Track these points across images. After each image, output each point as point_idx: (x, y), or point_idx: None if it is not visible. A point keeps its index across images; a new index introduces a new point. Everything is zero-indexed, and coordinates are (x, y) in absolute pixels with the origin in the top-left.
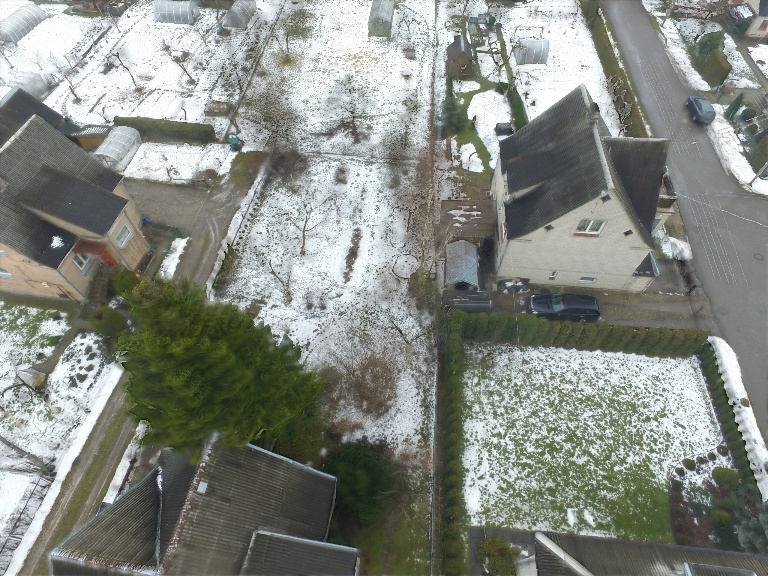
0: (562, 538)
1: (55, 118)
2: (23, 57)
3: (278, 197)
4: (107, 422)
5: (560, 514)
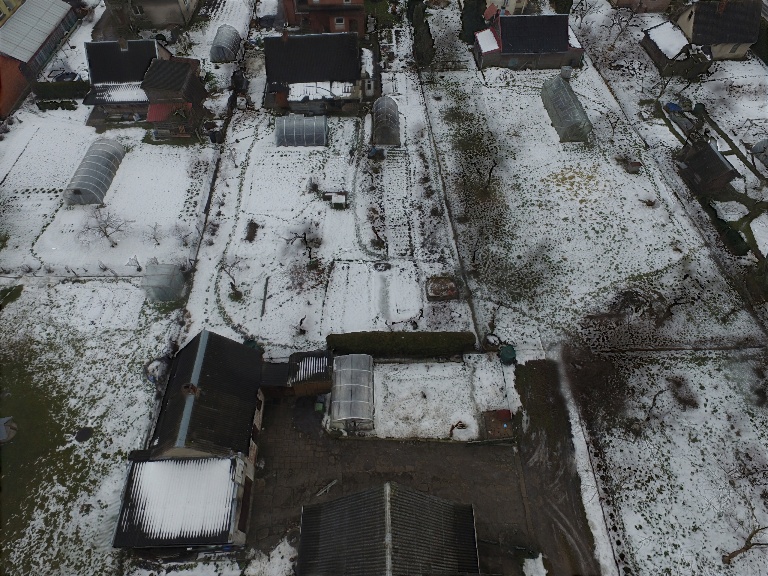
0: None
1: (256, 360)
2: (129, 230)
3: (620, 447)
4: None
5: None
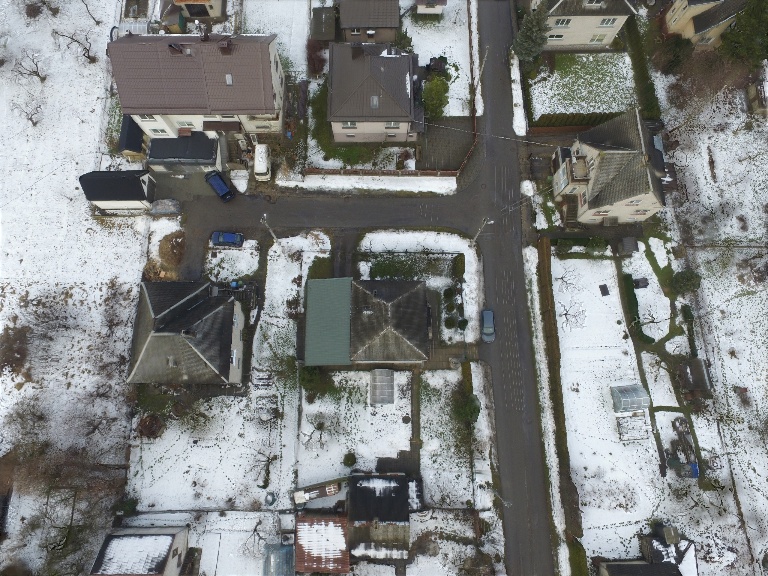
0: (630, 13)
1: None
2: None
3: None
4: None
5: (595, 59)
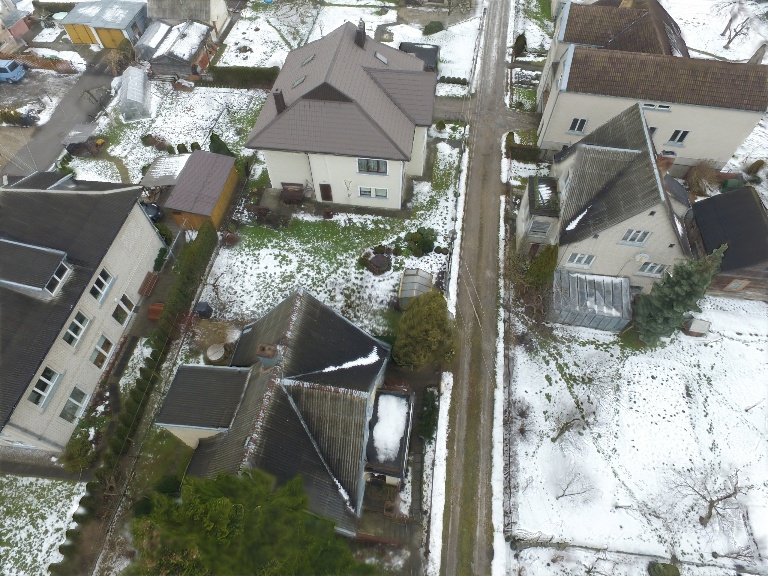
0: None
1: None
2: None
3: None
4: None
5: (2, 492)
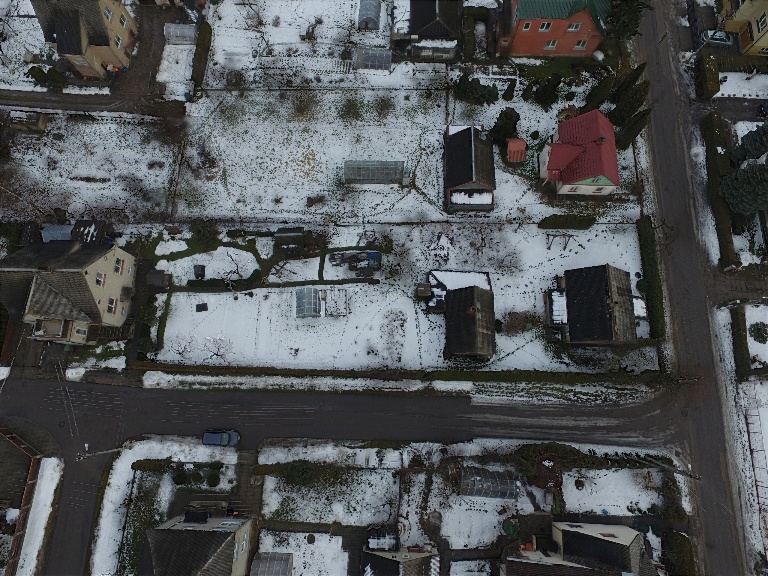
0: None
1: None
2: None
3: None
4: (5, 93)
5: None
